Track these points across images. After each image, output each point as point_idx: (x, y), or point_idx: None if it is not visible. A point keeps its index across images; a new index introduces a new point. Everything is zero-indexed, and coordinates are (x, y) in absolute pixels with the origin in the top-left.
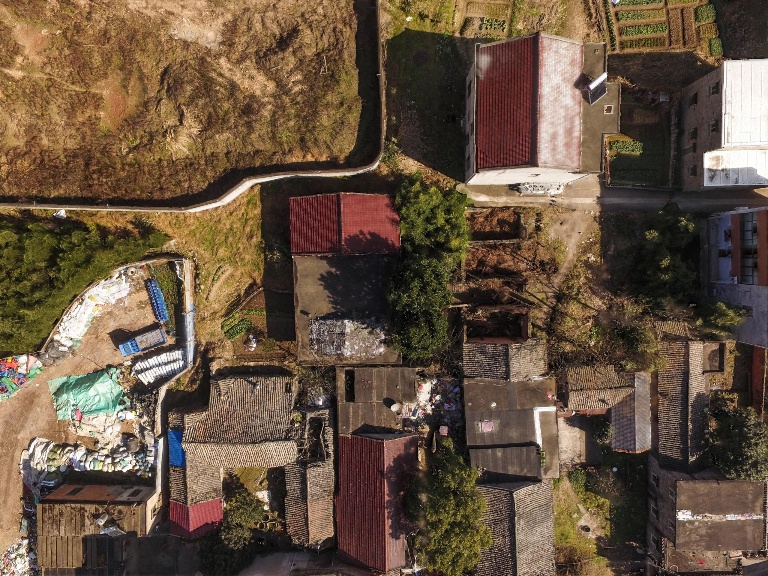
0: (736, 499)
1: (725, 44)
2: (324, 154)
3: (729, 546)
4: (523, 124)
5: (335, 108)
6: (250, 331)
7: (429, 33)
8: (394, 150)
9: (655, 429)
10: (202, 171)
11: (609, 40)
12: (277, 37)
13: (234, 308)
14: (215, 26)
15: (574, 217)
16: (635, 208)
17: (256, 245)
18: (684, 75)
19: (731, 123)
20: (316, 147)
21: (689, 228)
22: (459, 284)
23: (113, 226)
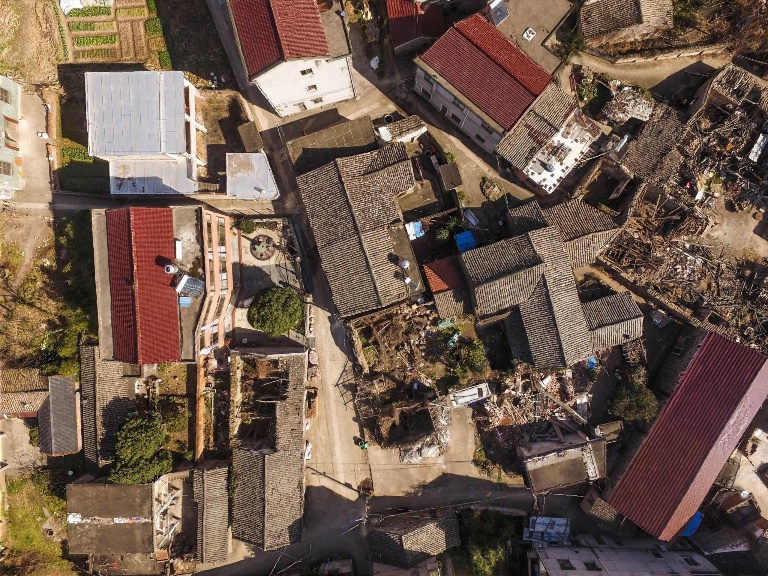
0: (124, 502)
1: (173, 57)
2: None
3: (119, 549)
4: None
5: None
6: None
7: None
8: None
9: (83, 433)
10: None
11: (62, 50)
12: None
13: None
14: None
15: (29, 222)
16: None
17: None
18: None
19: (95, 133)
20: None
21: None
22: None
23: None
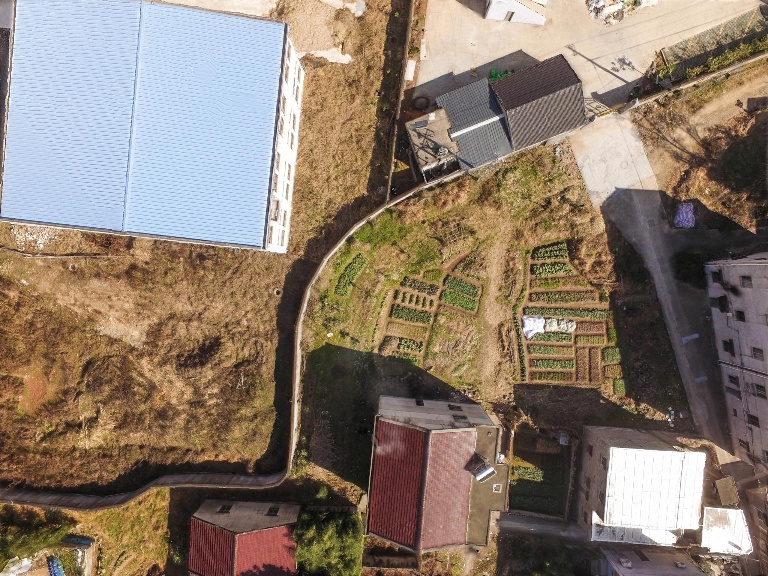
0: None
1: (628, 386)
2: (236, 456)
3: None
4: (410, 509)
5: (248, 422)
6: None
7: (348, 349)
8: (303, 464)
9: None
10: (113, 464)
11: (519, 370)
12: (200, 343)
13: None
14: (141, 326)
15: None
16: (532, 533)
17: (161, 535)
18: (587, 412)
19: (613, 505)
20: (228, 451)
21: None
22: None
23: (20, 506)
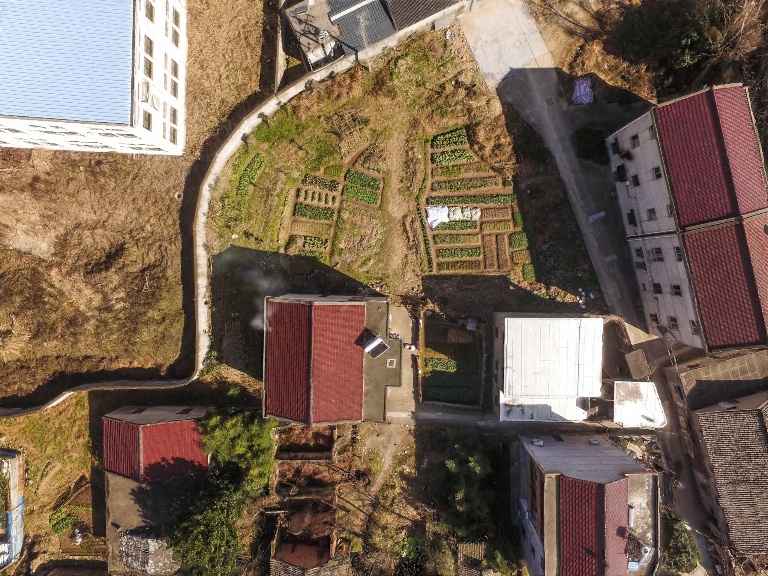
0: None
1: (537, 270)
2: (149, 362)
3: None
4: (300, 383)
5: (156, 324)
6: (76, 525)
7: (254, 250)
8: (213, 364)
9: None
10: (31, 375)
11: (427, 261)
12: (106, 251)
13: (62, 502)
14: (48, 238)
15: (390, 429)
16: (448, 424)
17: (84, 444)
18: (497, 299)
19: (512, 376)
20: (141, 356)
21: (476, 470)
22: (271, 496)
23: None
